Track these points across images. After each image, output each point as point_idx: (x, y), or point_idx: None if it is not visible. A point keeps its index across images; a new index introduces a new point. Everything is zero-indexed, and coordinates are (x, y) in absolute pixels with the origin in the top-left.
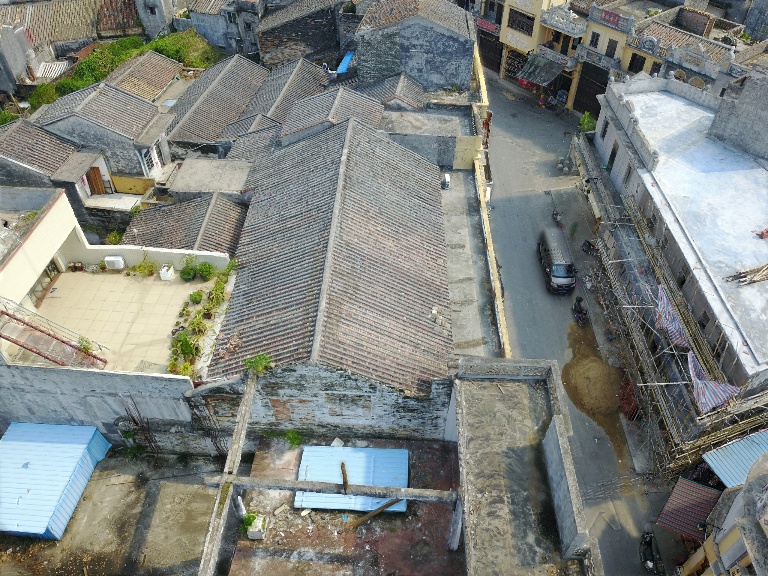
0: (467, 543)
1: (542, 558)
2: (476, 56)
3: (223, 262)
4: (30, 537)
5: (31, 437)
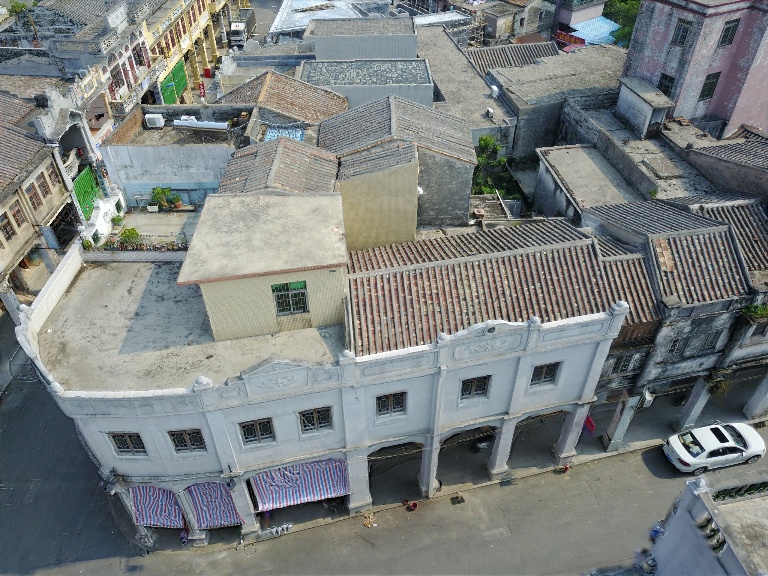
0: (73, 37)
1: None
2: None
3: (31, 3)
4: None
5: None
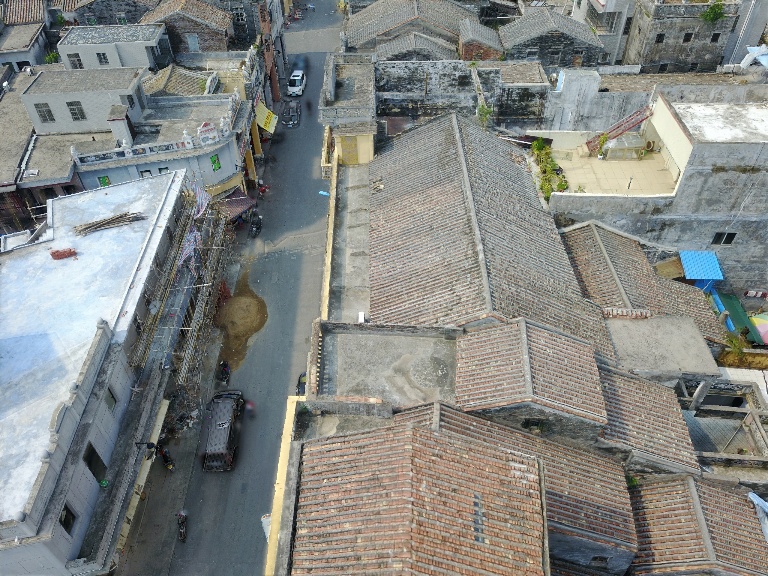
0: None
1: None
2: None
3: None
4: None
5: None
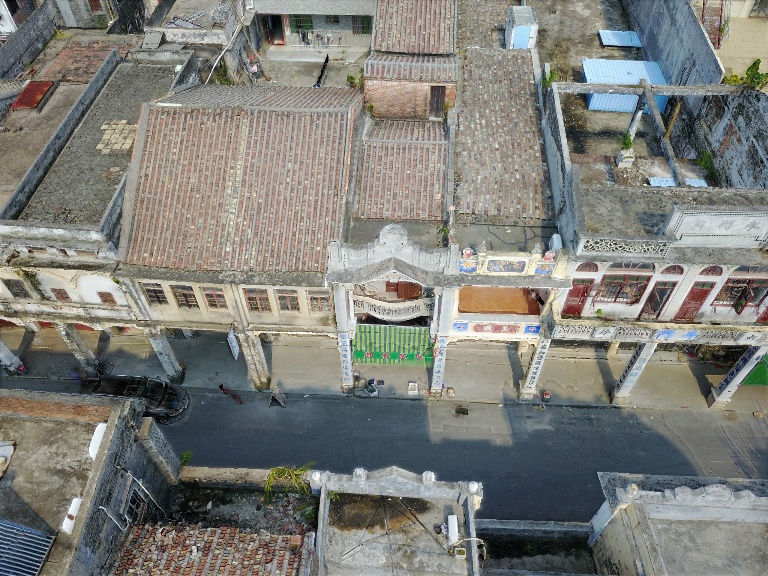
0: None
1: (649, 230)
2: None
3: None
4: (586, 98)
5: (650, 71)
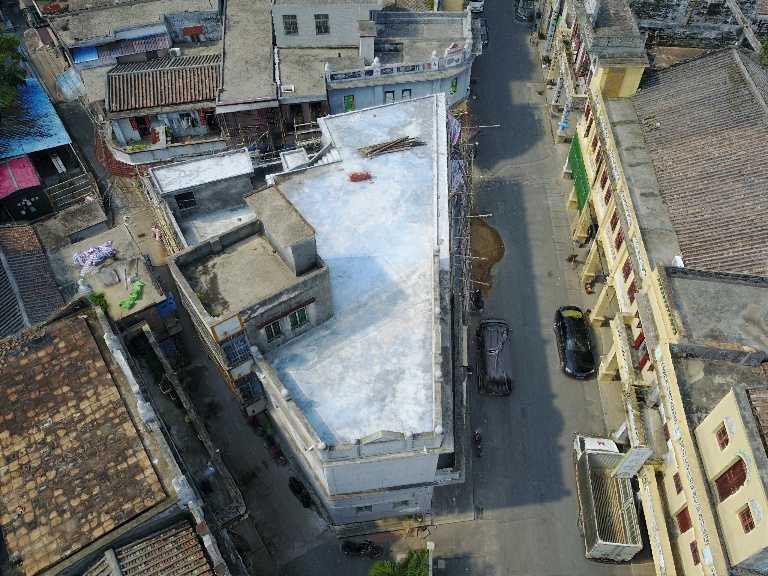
0: None
1: None
2: (711, 517)
3: None
4: None
5: None
